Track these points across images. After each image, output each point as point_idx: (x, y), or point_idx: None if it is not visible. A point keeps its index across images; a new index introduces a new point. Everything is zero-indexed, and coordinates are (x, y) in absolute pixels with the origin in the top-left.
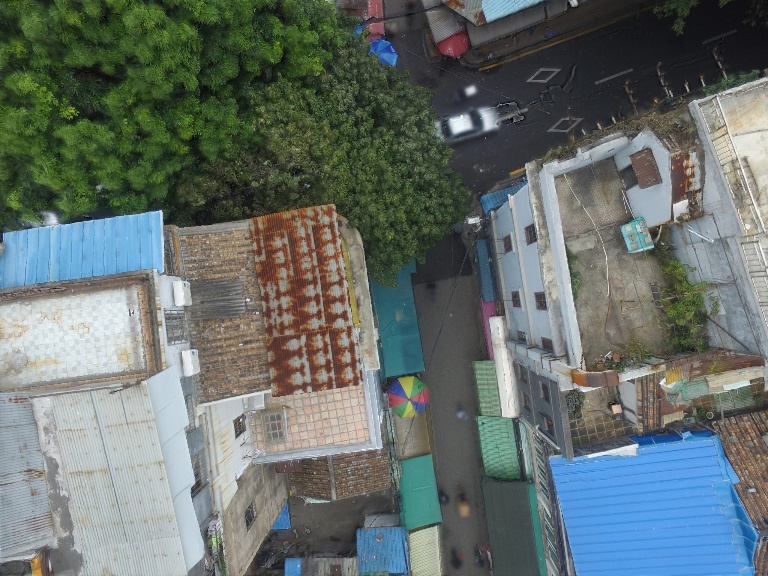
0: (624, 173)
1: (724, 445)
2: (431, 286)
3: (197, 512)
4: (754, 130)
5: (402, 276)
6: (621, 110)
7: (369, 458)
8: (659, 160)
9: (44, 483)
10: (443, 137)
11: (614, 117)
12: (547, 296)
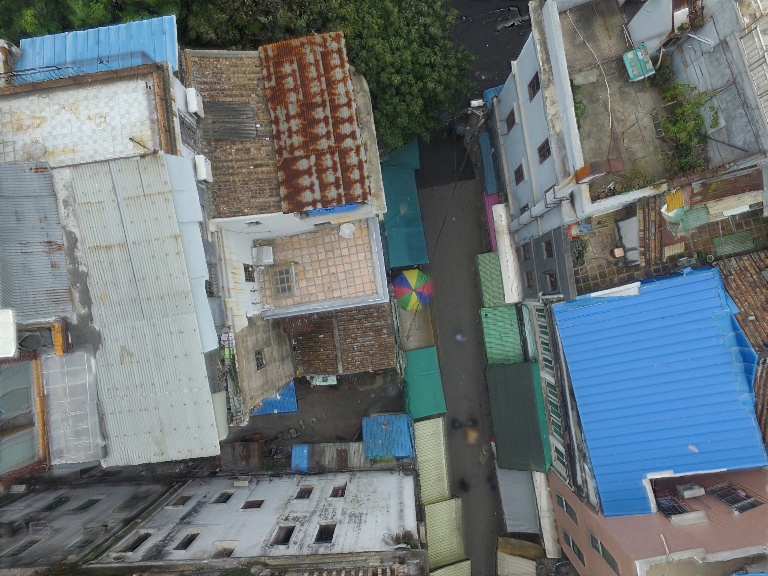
0: (625, 8)
1: (724, 281)
2: (434, 191)
3: (211, 312)
4: None
5: (406, 171)
6: None
7: (375, 336)
8: None
9: (63, 257)
10: None
11: None
12: (551, 129)
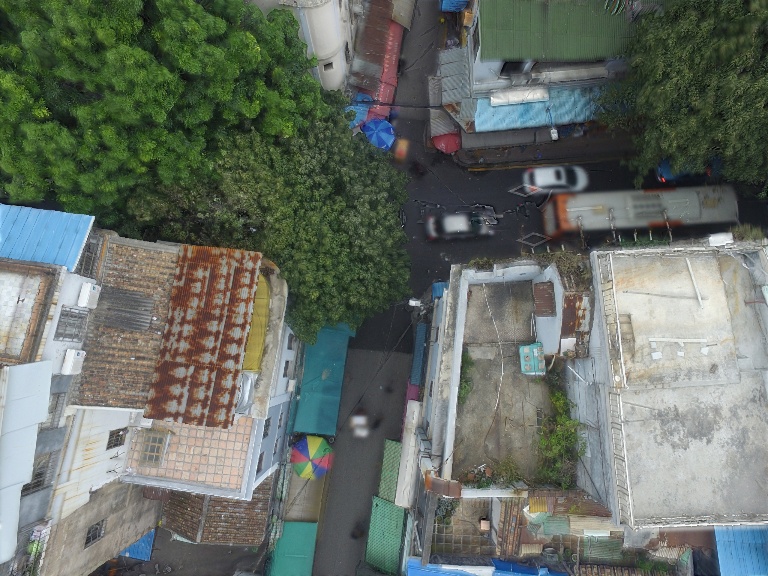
0: None
1: None
2: (370, 354)
3: (24, 512)
4: (644, 292)
5: (340, 337)
6: (588, 240)
7: (248, 509)
8: (557, 295)
9: None
10: (393, 220)
11: (580, 245)
12: (438, 393)
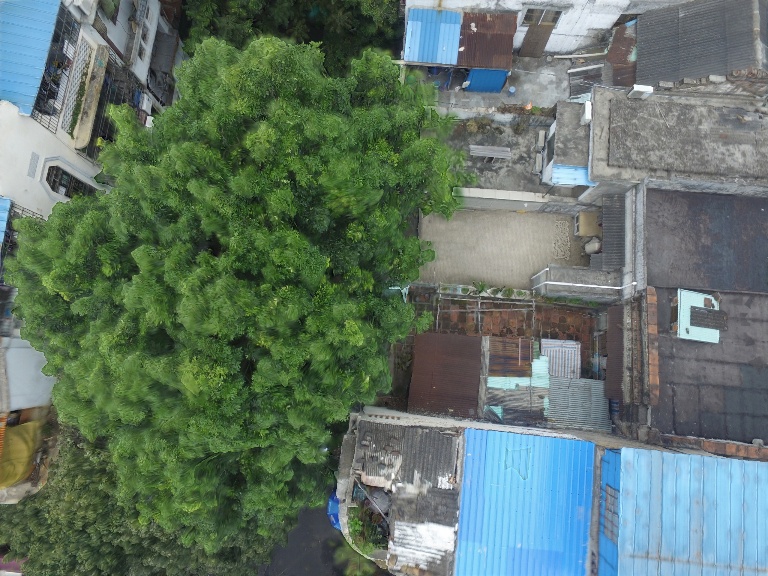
0: None
1: None
2: None
3: None
4: None
5: None
6: None
7: None
8: None
9: None
10: None
11: None
12: None
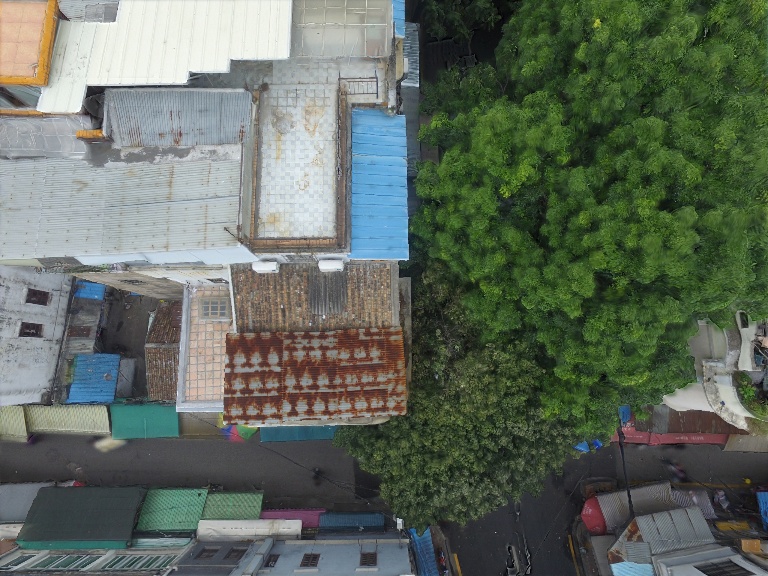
0: None
1: None
2: None
3: None
4: None
5: None
6: None
7: None
8: None
9: (169, 144)
10: None
11: None
12: None
